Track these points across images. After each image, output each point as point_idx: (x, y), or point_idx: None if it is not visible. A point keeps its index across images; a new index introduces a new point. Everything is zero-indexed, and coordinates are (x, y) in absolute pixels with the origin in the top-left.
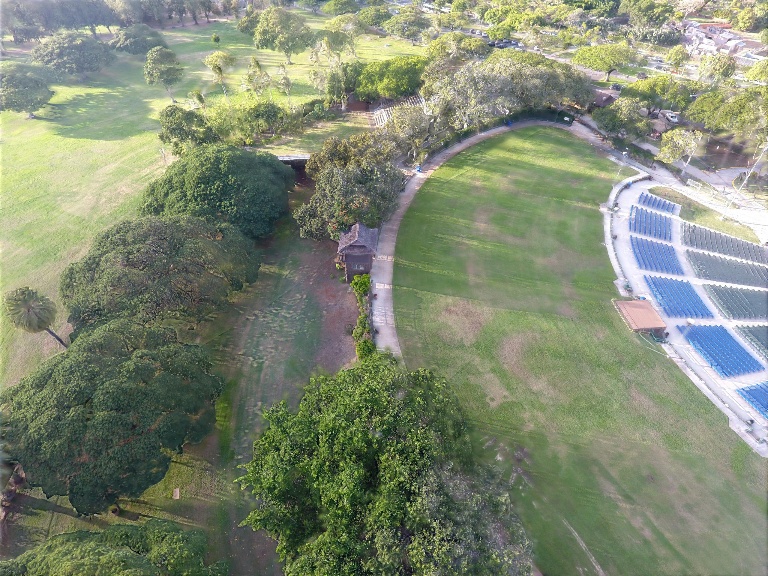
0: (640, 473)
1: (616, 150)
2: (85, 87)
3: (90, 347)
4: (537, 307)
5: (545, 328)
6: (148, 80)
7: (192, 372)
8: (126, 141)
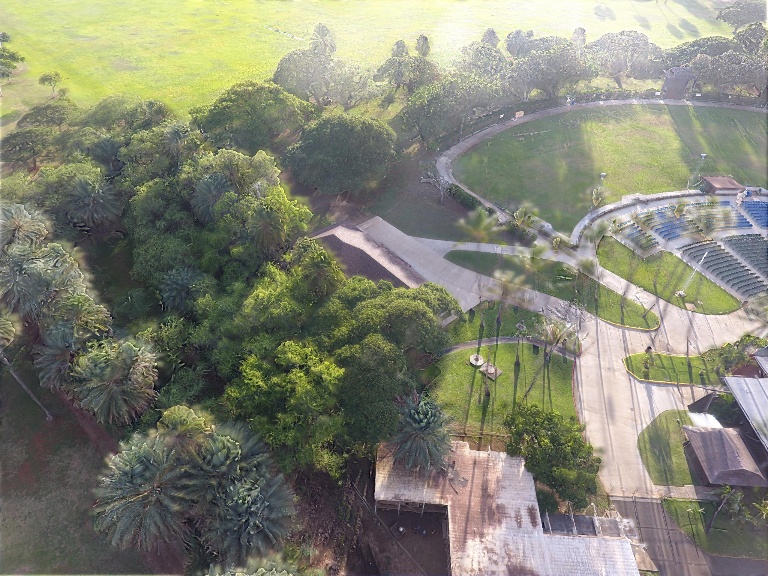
0: (585, 153)
1: None
2: None
3: (566, 40)
4: (690, 145)
5: (672, 145)
6: None
7: None
8: None
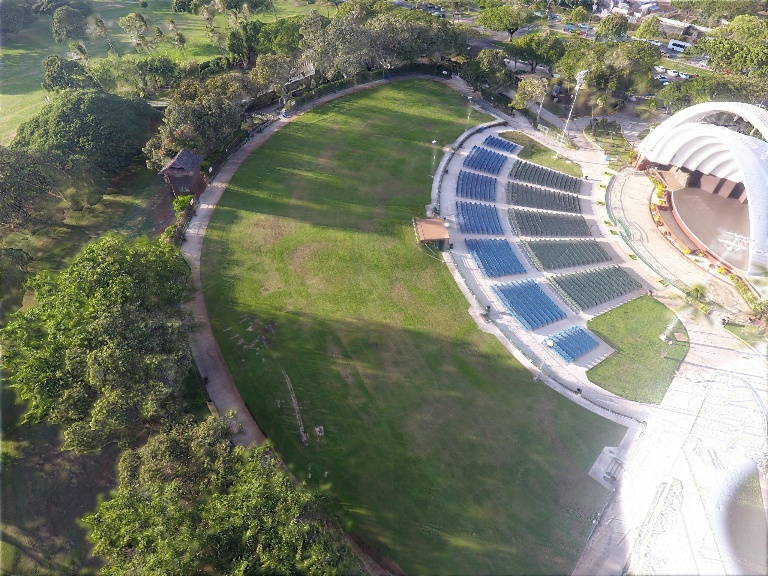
0: (368, 341)
1: (484, 100)
2: (5, 48)
3: None
4: (341, 223)
5: (340, 239)
6: (56, 39)
7: (3, 266)
8: (29, 95)
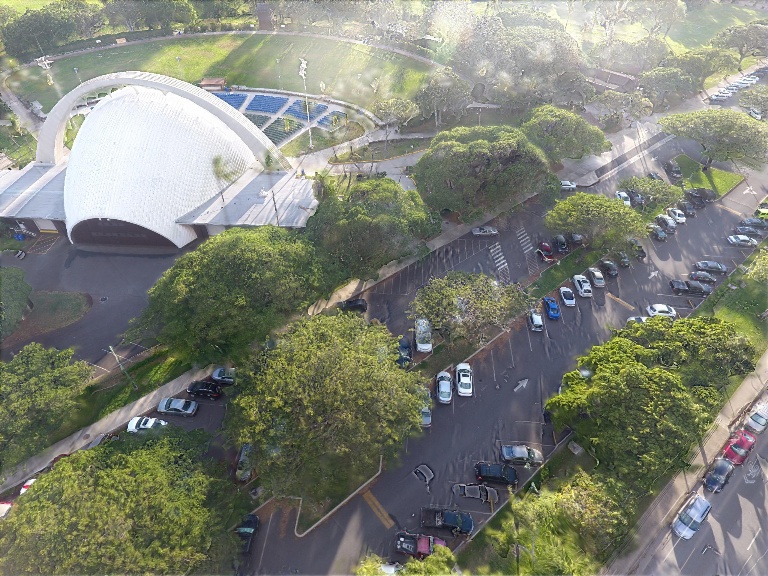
0: None
1: None
2: None
3: None
4: None
5: None
6: None
7: (217, 6)
8: None
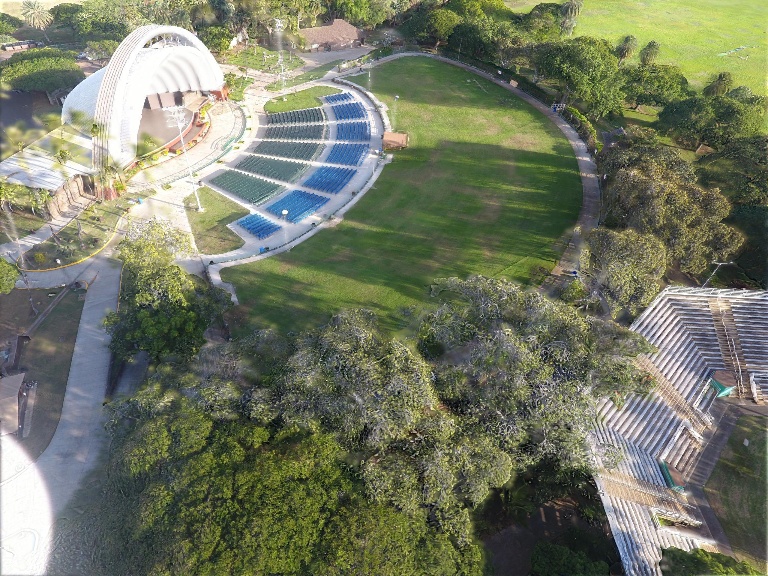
0: None
1: None
2: None
3: None
4: (468, 145)
5: (467, 136)
6: None
7: None
8: None
